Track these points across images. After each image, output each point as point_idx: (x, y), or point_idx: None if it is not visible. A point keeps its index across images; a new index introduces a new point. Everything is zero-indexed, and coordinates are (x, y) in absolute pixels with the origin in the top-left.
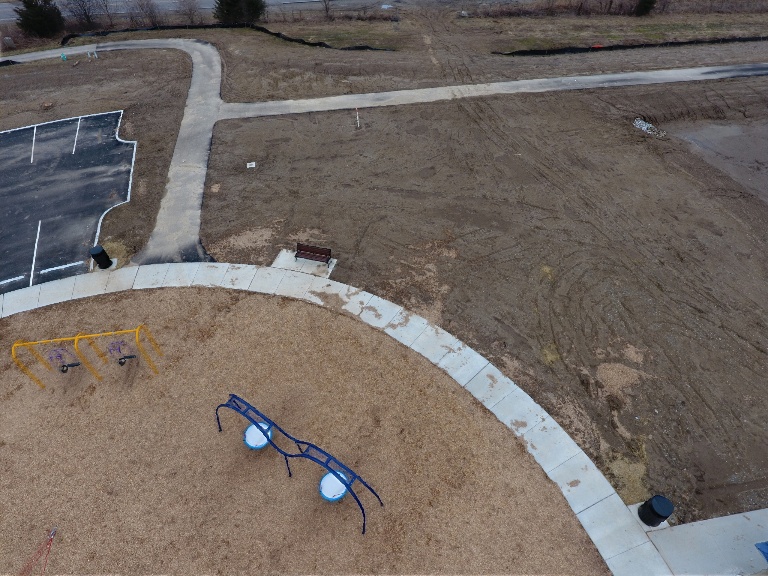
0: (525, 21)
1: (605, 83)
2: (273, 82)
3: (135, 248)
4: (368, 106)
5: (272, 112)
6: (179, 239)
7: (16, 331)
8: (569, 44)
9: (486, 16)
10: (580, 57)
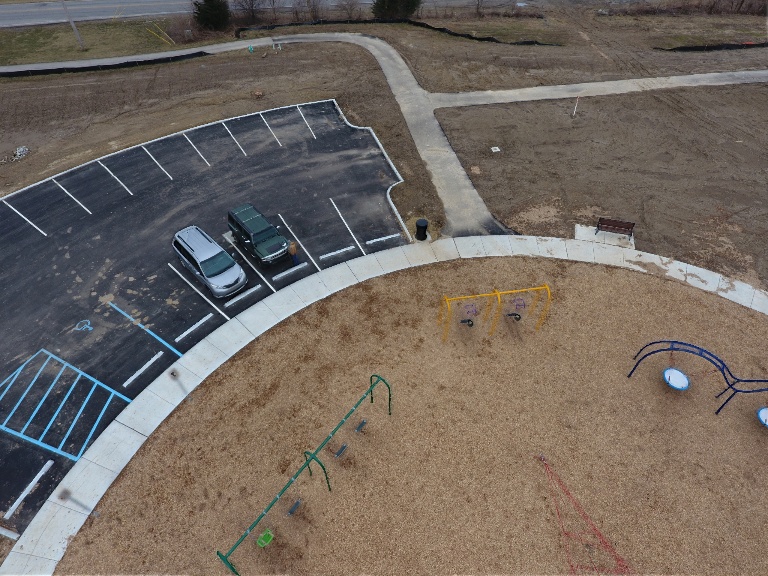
0: (664, 19)
1: None
2: (462, 74)
3: (440, 222)
4: (568, 97)
5: (481, 102)
6: (474, 215)
7: (382, 293)
8: (720, 41)
9: (624, 14)
10: (738, 53)
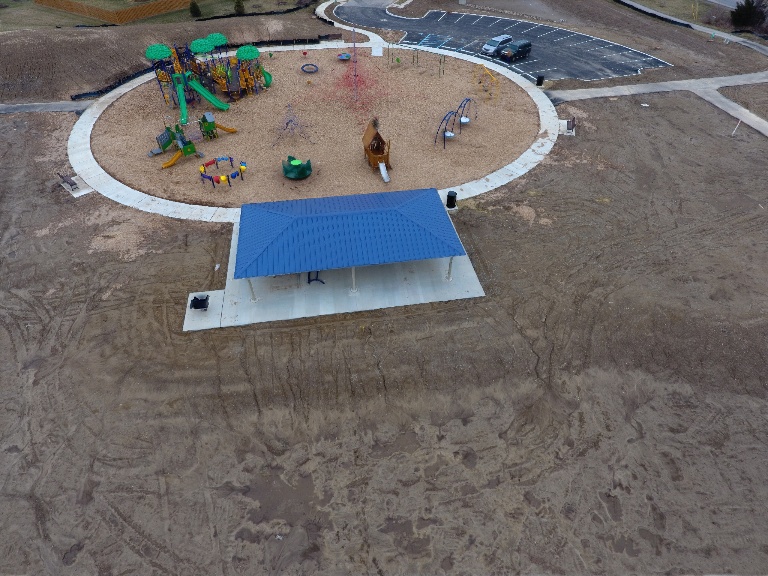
0: None
1: None
2: None
3: (553, 88)
4: None
5: (720, 105)
6: (565, 96)
7: (496, 77)
8: None
9: None
10: None
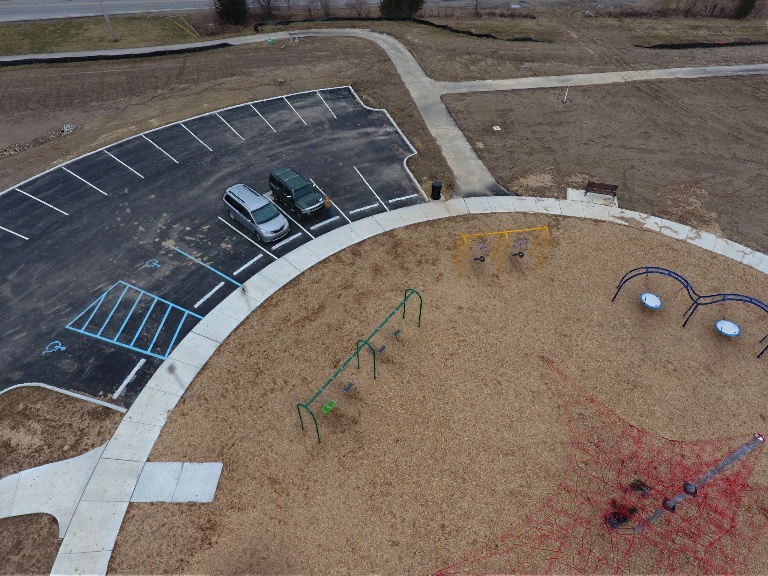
0: (645, 21)
1: (743, 72)
2: (464, 66)
3: (451, 186)
4: (559, 86)
5: (482, 89)
6: (480, 180)
7: (406, 240)
8: (695, 40)
9: (609, 16)
10: (710, 51)
